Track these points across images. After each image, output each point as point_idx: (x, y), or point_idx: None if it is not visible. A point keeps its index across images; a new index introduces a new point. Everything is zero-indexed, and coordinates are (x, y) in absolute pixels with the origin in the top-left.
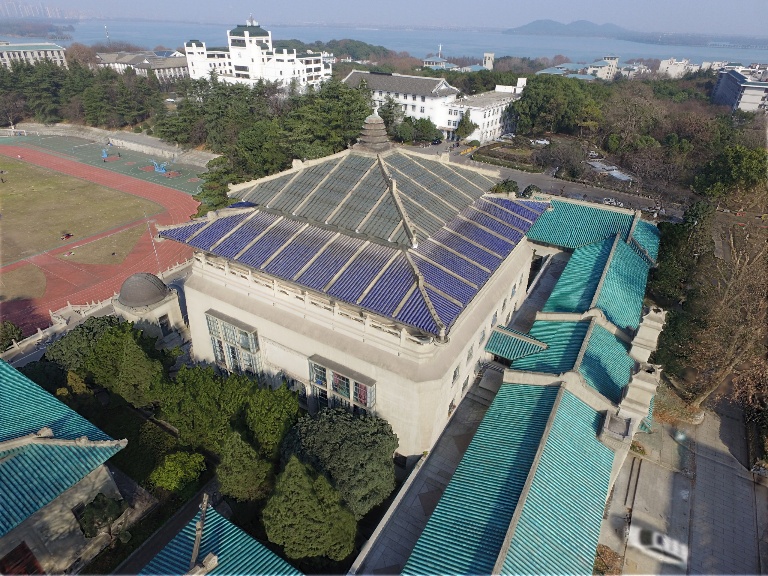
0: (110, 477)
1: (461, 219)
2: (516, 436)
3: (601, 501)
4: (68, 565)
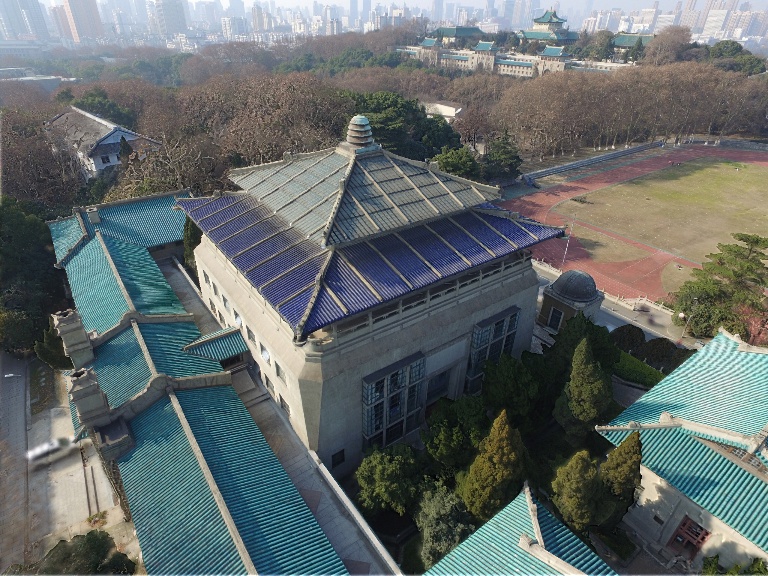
0: None
1: (285, 228)
2: (147, 296)
3: None
4: None
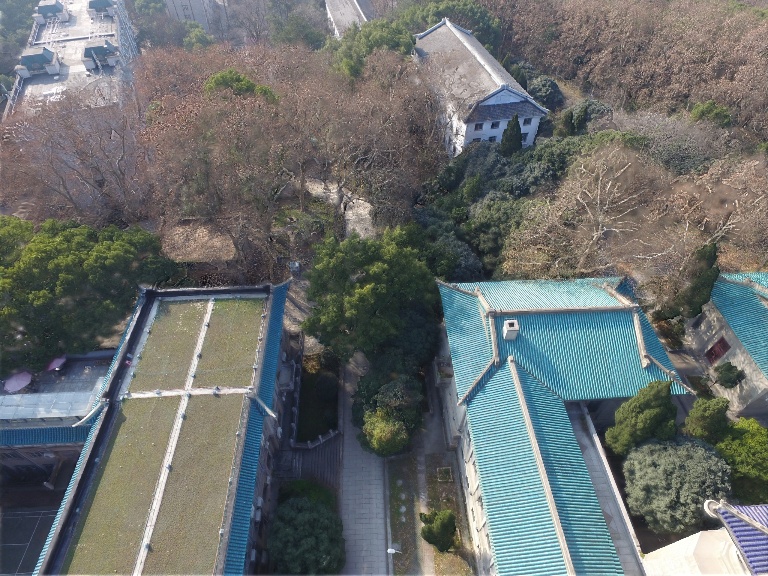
0: (761, 393)
1: None
2: None
3: (503, 571)
4: (712, 376)
